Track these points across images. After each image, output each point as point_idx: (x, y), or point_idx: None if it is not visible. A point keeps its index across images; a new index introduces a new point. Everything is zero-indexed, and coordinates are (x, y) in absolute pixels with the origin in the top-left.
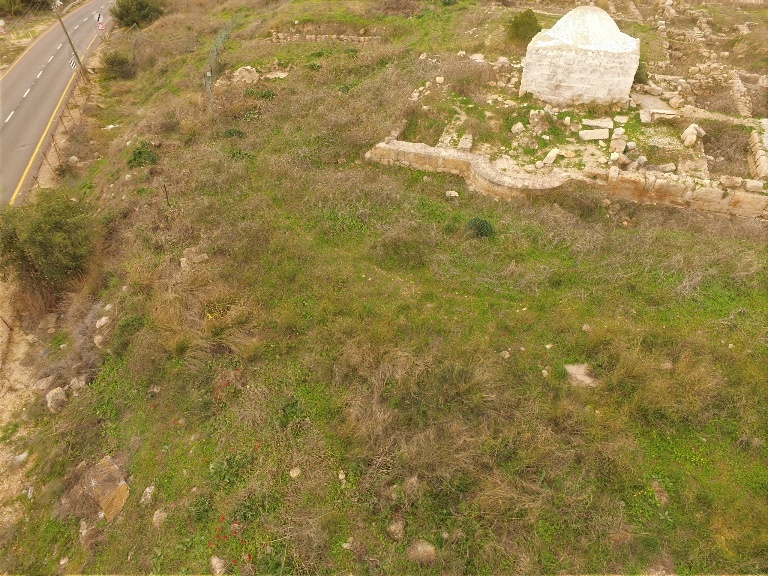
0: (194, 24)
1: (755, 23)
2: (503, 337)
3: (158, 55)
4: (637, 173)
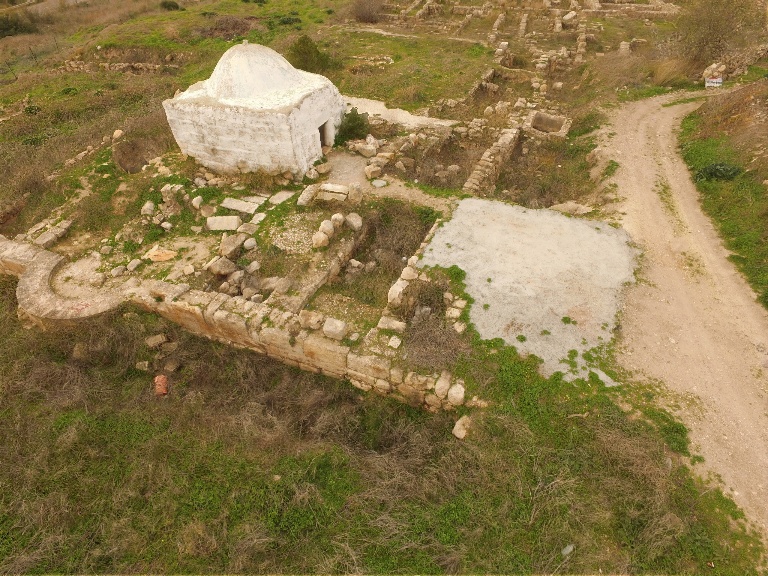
0: None
1: (642, 40)
2: None
3: None
4: (206, 296)
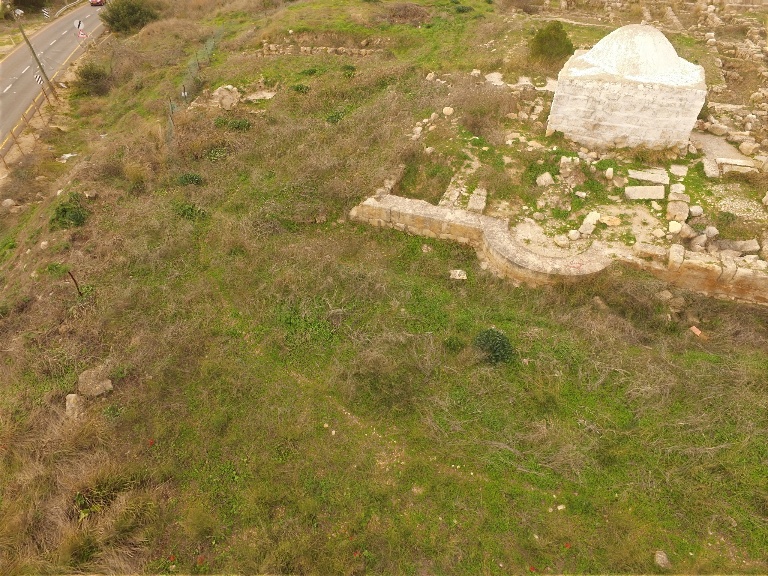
0: (182, 32)
1: None
2: (528, 569)
3: (136, 68)
4: (709, 256)
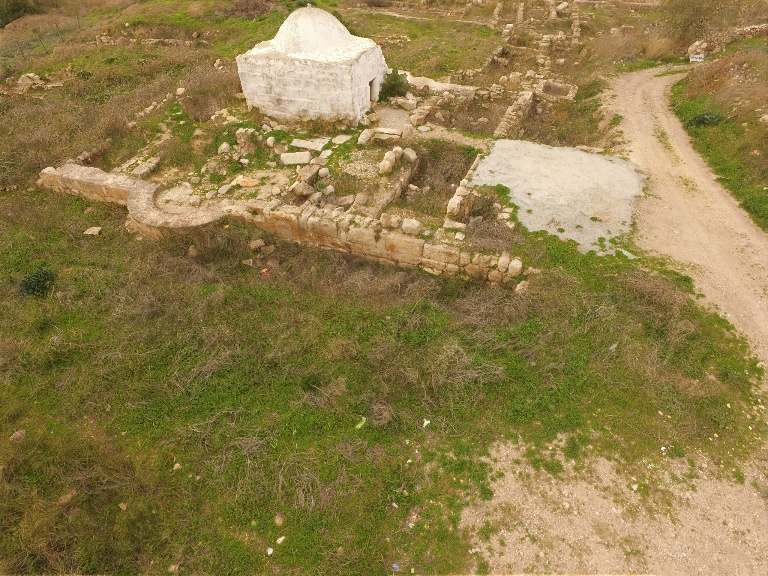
0: (40, 26)
1: (630, 27)
2: None
3: None
4: (297, 208)
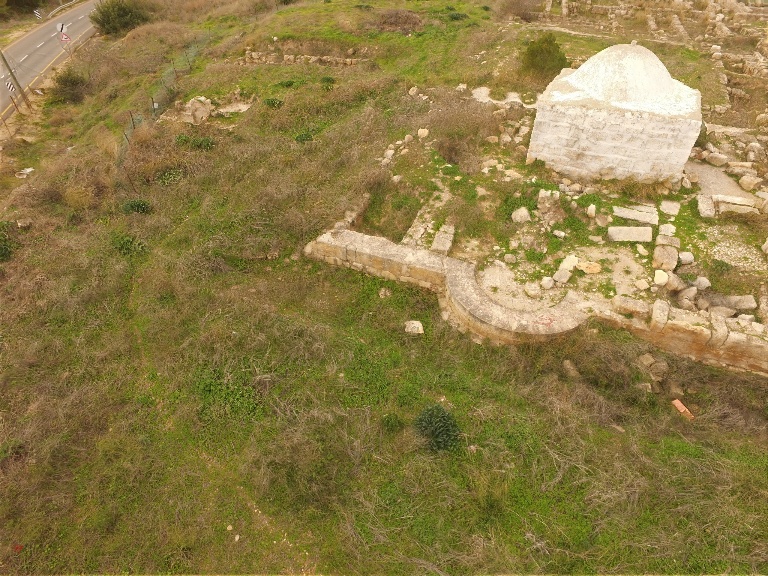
0: (167, 36)
1: None
2: None
3: (113, 75)
4: (697, 315)
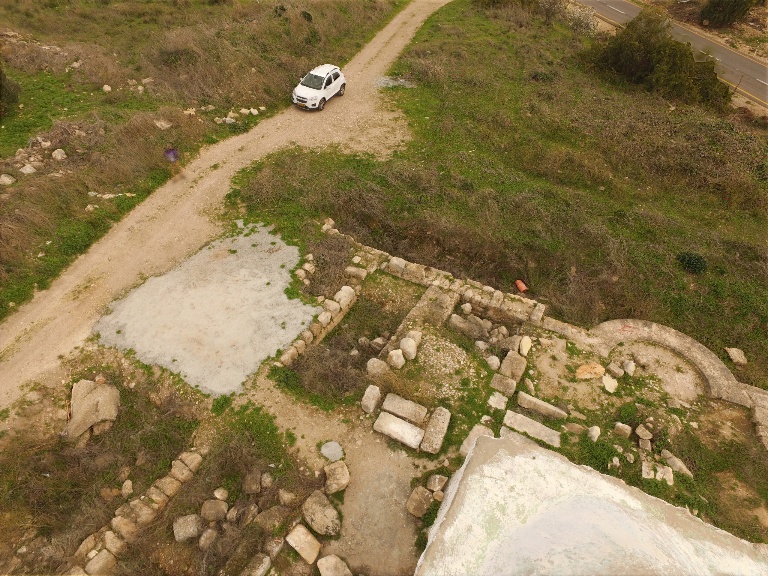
0: None
1: None
2: None
3: None
4: (510, 307)
